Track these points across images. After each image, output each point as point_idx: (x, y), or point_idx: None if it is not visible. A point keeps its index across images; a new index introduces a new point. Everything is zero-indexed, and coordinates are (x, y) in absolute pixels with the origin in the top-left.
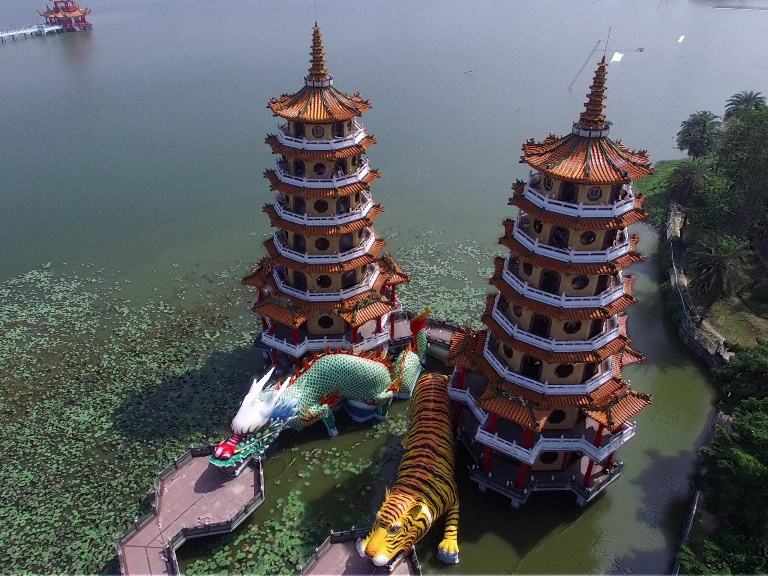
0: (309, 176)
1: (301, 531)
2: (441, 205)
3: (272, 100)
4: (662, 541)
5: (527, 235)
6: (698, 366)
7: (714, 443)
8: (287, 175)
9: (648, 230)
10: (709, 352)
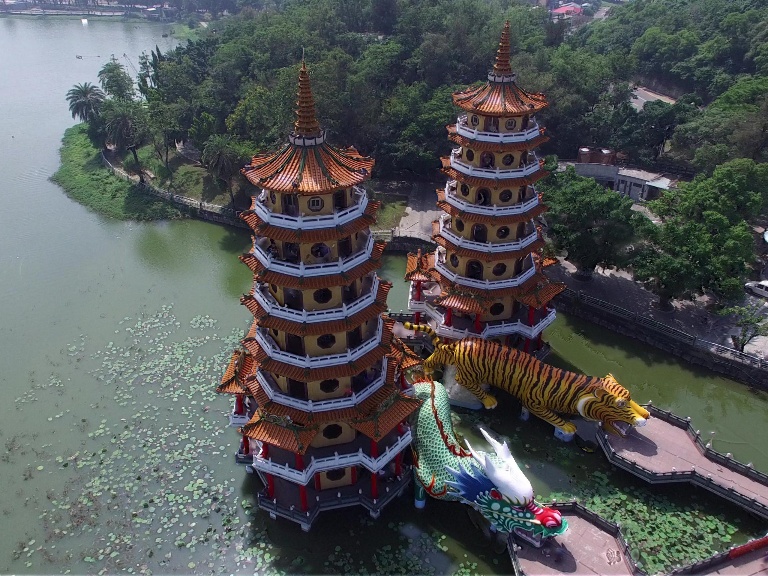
0: (356, 246)
1: (585, 496)
2: (3, 328)
3: (296, 183)
4: (556, 314)
5: (512, 169)
6: (391, 254)
7: (558, 237)
8: (347, 260)
9: (182, 221)
10: (388, 242)
